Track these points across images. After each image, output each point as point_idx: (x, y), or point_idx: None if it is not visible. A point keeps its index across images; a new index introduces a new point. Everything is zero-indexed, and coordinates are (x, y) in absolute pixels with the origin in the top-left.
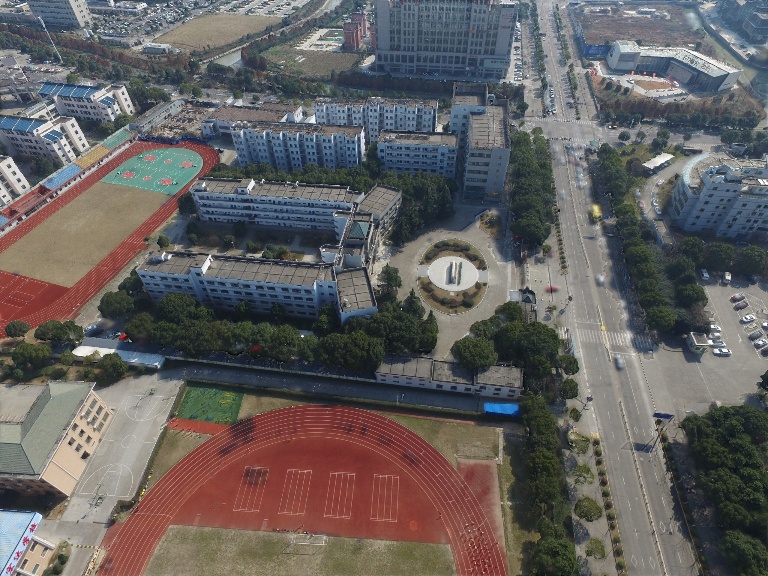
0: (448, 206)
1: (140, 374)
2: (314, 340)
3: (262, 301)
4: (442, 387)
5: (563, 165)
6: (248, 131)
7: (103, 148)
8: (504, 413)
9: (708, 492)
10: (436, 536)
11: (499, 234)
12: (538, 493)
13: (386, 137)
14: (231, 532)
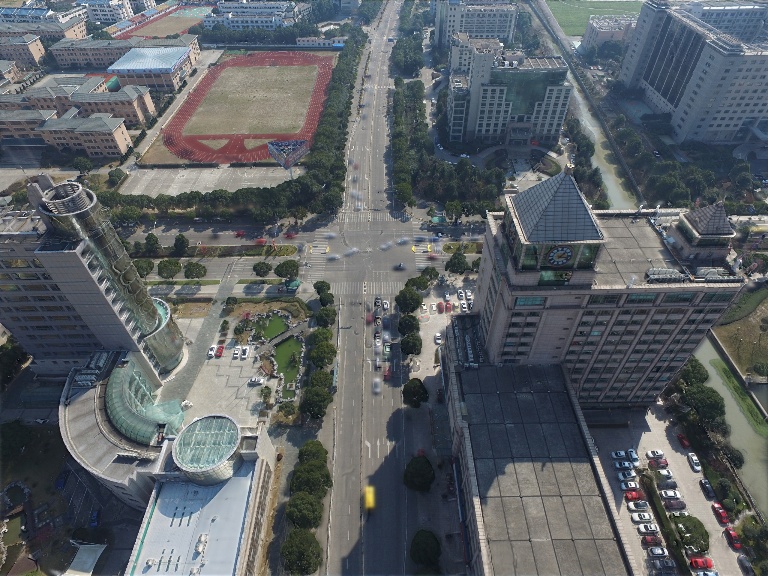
0: (332, 10)
1: (208, 49)
2: None
3: None
4: (320, 45)
5: (392, 5)
6: None
7: (166, 5)
8: (340, 46)
9: None
10: (313, 64)
11: (354, 21)
12: None
13: None
14: None
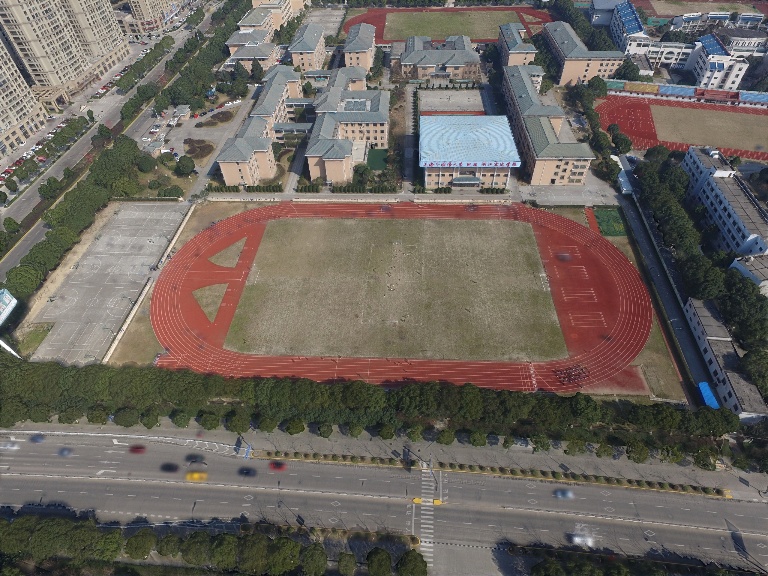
0: None
1: (613, 187)
2: (695, 252)
3: (715, 222)
4: (706, 354)
5: None
6: None
7: None
8: (705, 400)
9: (709, 571)
10: (572, 349)
11: None
12: (634, 407)
13: None
14: (536, 248)
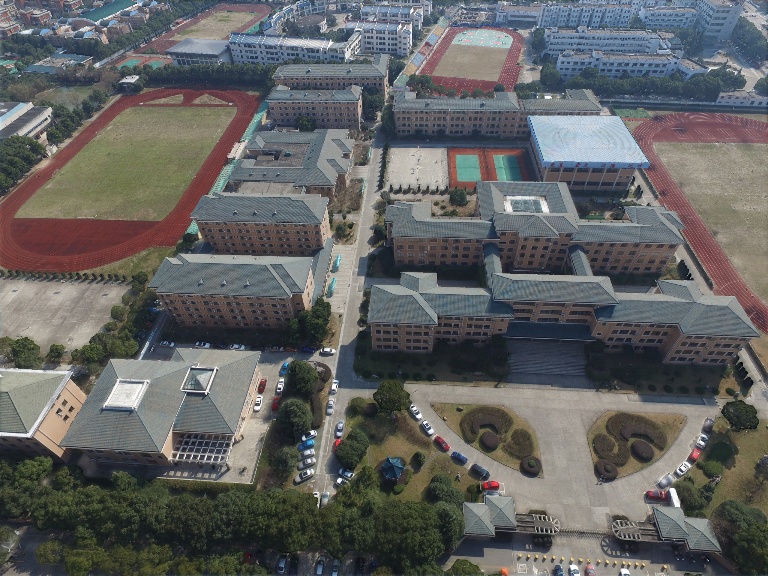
0: (703, 42)
1: None
2: None
3: (630, 76)
4: (753, 104)
5: None
6: (555, 8)
7: (440, 27)
8: None
9: None
10: None
11: (735, 59)
12: None
13: (650, 8)
14: (685, 143)
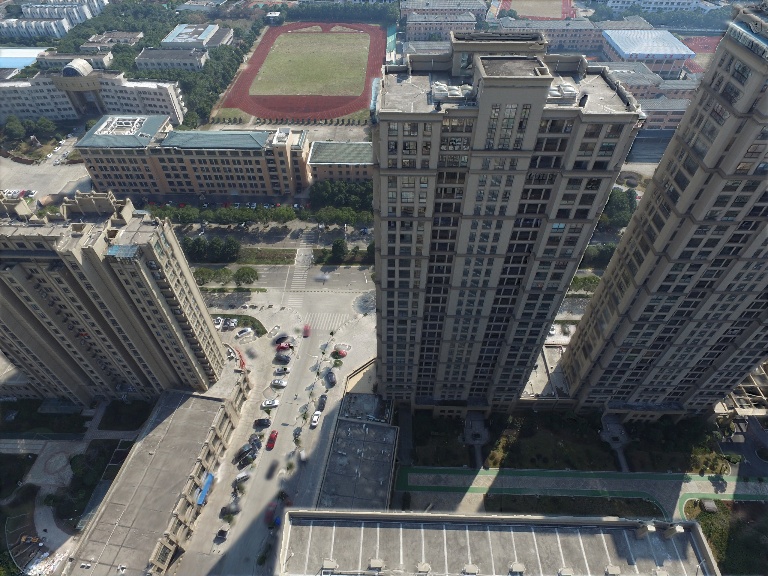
0: None
1: None
2: None
3: None
4: None
5: None
6: None
7: None
8: None
9: None
10: None
11: (736, 5)
12: None
13: None
14: (710, 53)
